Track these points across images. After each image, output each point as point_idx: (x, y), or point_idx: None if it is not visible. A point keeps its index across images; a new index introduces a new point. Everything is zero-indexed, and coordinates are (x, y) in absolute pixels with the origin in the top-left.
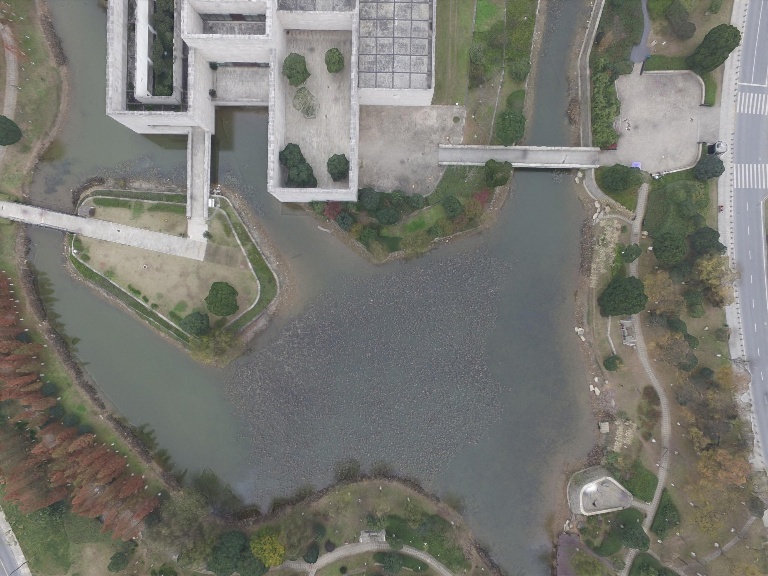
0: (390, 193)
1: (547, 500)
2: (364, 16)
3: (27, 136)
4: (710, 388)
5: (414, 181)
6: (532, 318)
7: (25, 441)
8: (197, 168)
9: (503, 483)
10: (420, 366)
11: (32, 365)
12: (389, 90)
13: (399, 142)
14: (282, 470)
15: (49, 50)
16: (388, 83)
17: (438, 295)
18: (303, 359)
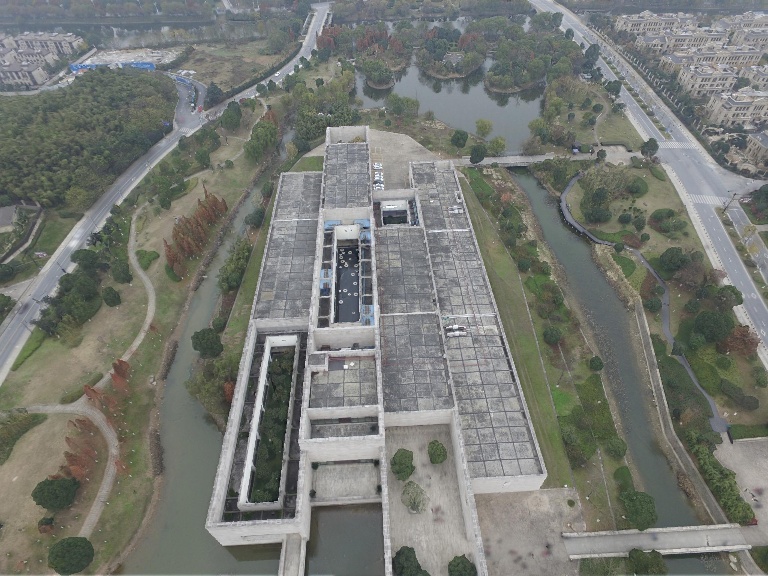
0: None
1: None
2: (461, 411)
3: (95, 560)
4: None
5: None
6: None
7: None
8: None
9: None
10: None
11: None
12: (502, 478)
13: (517, 534)
14: None
15: (150, 461)
16: (498, 471)
17: None
18: None
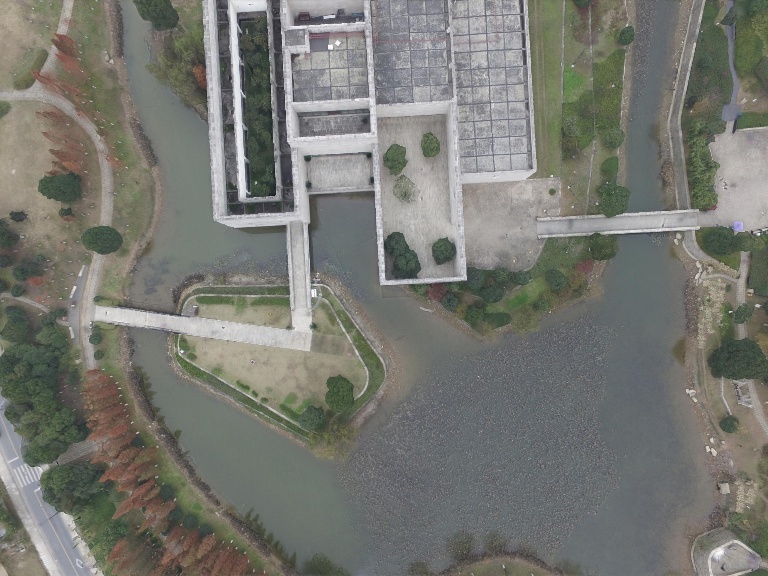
0: (491, 270)
1: (671, 565)
2: (460, 101)
3: (125, 240)
4: None
5: (514, 256)
6: (641, 383)
7: (146, 546)
8: (297, 259)
9: (625, 551)
10: (533, 439)
11: (150, 471)
12: (491, 173)
13: (496, 218)
14: (402, 554)
15: (140, 153)
16: (489, 166)
17: (545, 367)
18: (415, 441)
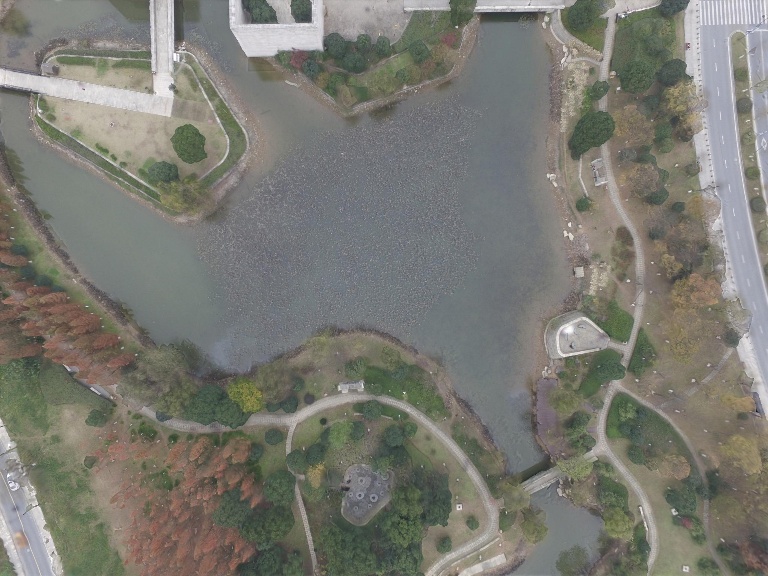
0: None
1: (525, 348)
2: None
3: None
4: (682, 221)
5: (380, 29)
6: (504, 166)
7: None
8: (160, 23)
9: (480, 333)
10: (393, 218)
11: (0, 222)
12: None
13: None
14: (259, 328)
15: None
16: None
17: (409, 146)
18: (276, 215)
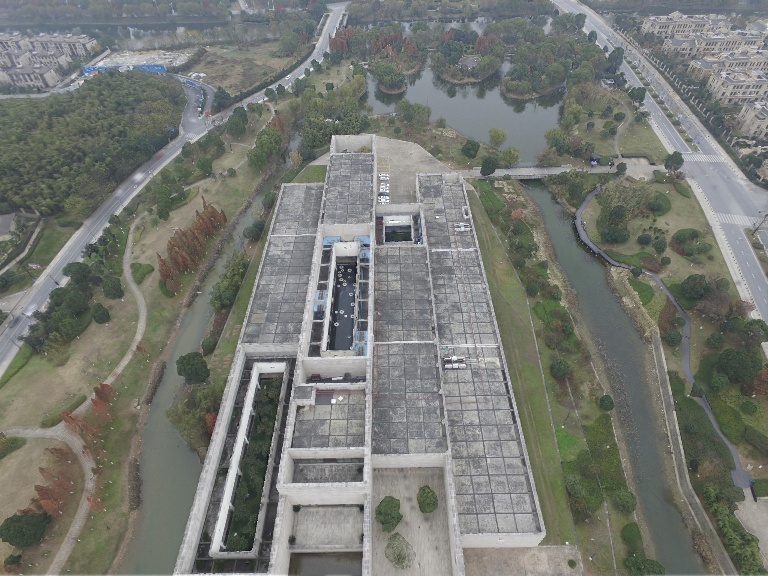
0: None
1: None
2: (455, 455)
3: None
4: None
5: None
6: None
7: None
8: None
9: None
10: None
11: None
12: (495, 535)
13: None
14: None
15: (127, 494)
16: (492, 526)
17: None
18: None
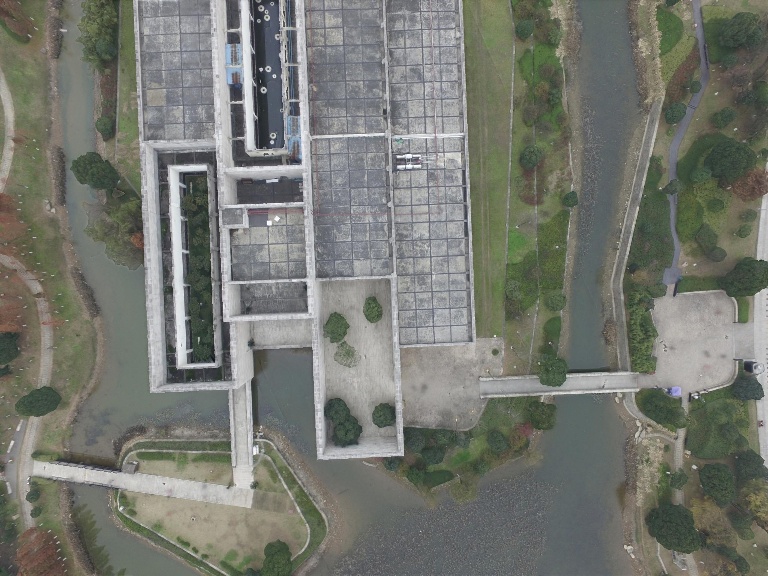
0: (434, 428)
1: None
2: (401, 272)
3: (65, 393)
4: None
5: (457, 415)
6: (581, 538)
7: None
8: (239, 416)
9: None
10: None
11: None
12: None
13: (440, 377)
14: None
15: (82, 303)
16: (429, 337)
17: (487, 522)
18: None
